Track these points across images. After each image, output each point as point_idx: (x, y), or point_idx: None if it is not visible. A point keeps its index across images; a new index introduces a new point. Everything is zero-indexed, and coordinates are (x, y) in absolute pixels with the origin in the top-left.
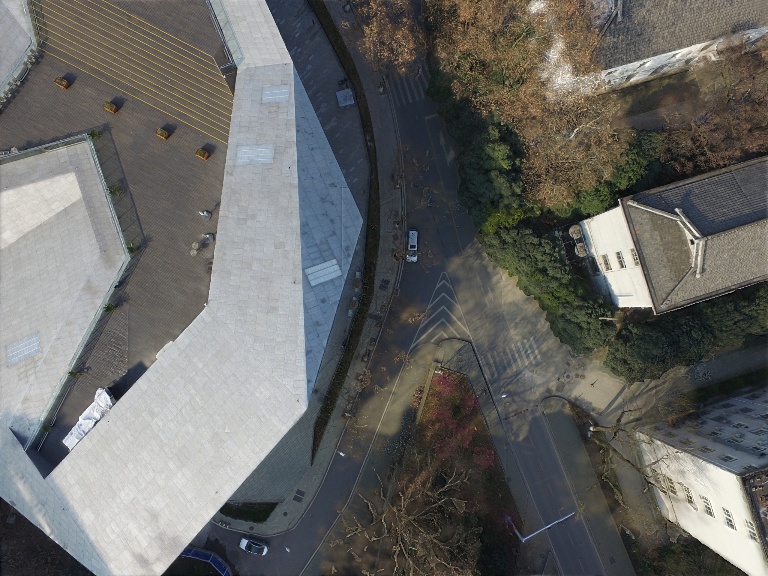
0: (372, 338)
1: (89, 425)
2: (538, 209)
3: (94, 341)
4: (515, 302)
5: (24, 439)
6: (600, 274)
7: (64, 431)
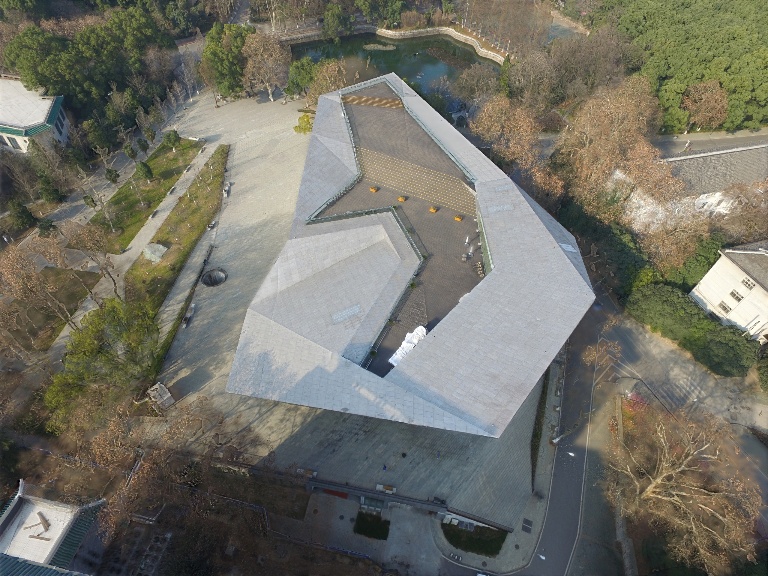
0: (559, 378)
1: (410, 348)
2: (660, 276)
3: (402, 305)
4: (663, 352)
5: None
6: (722, 321)
7: (384, 360)
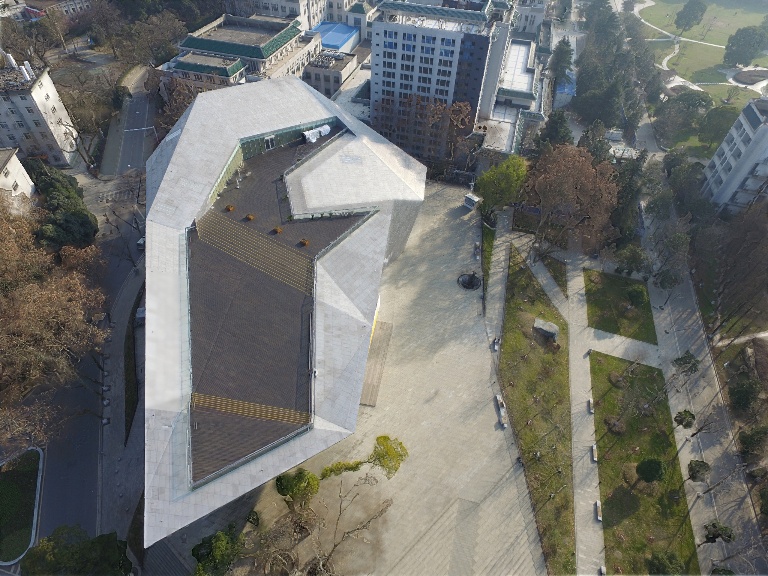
0: None
1: None
2: None
3: None
4: (97, 216)
5: (351, 133)
6: None
7: (333, 134)
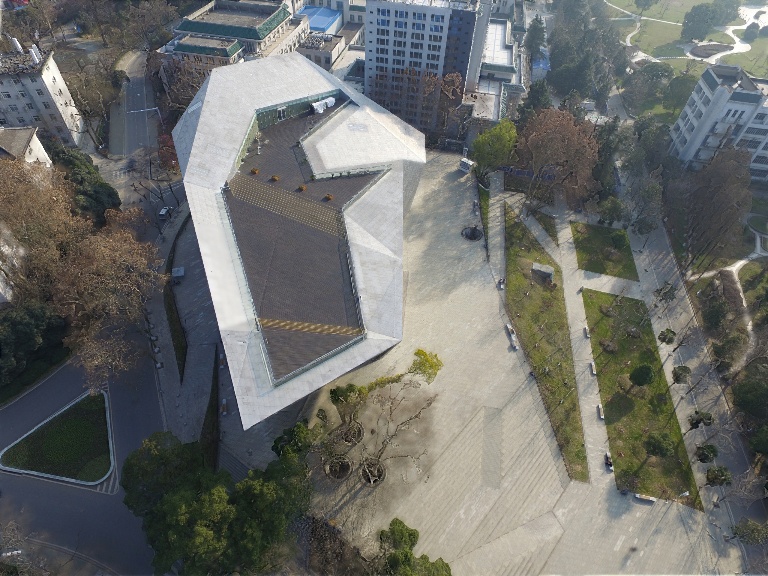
0: None
1: None
2: None
3: None
4: None
5: (354, 104)
6: None
7: (337, 105)
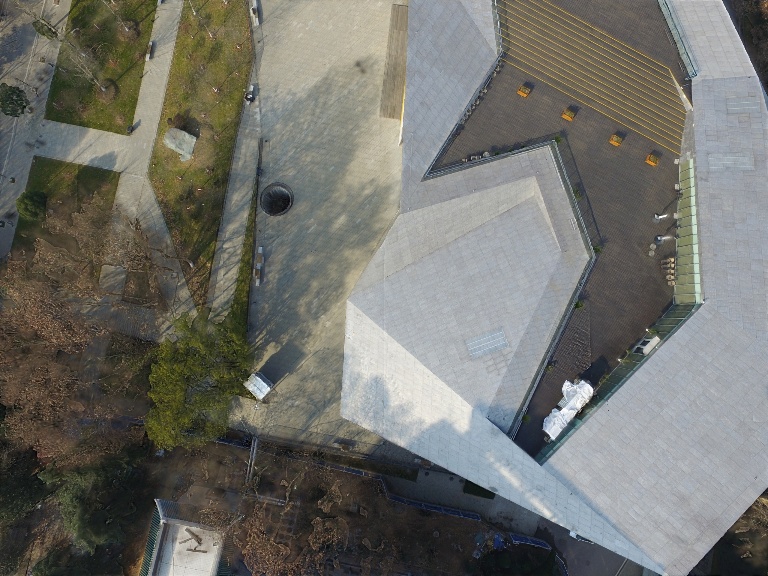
0: None
1: (571, 415)
2: None
3: (560, 336)
4: None
5: (500, 428)
6: None
7: (535, 421)
